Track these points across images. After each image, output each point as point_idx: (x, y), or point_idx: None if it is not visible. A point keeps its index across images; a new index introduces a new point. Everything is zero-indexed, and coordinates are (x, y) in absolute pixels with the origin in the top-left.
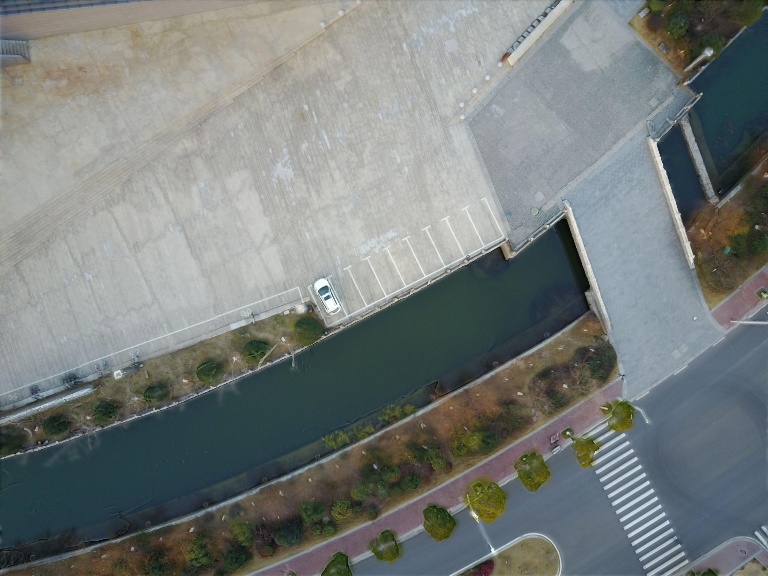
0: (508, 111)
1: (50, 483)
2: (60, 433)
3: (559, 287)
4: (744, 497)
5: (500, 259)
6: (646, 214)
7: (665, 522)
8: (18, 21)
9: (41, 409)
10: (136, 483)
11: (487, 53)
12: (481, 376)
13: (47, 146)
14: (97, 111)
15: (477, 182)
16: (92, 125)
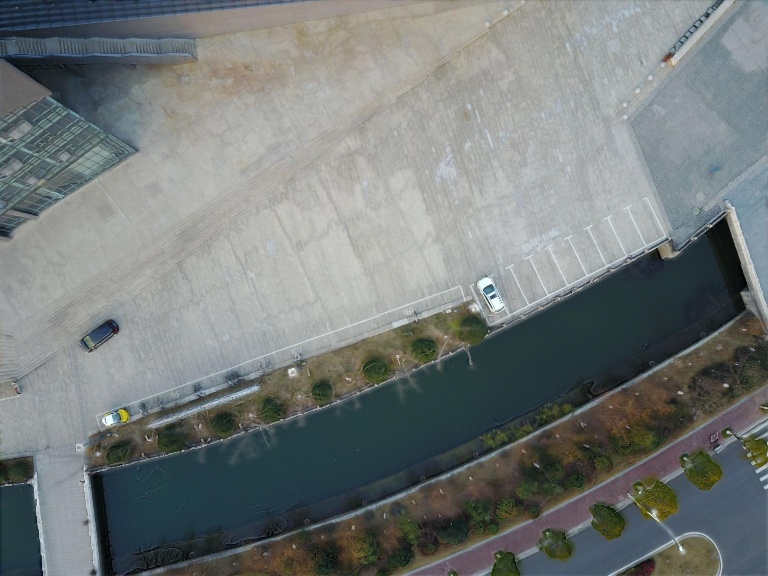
0: (669, 111)
1: (198, 481)
2: (228, 431)
3: (714, 287)
4: None
5: (656, 258)
6: None
7: None
8: (195, 20)
9: (208, 407)
10: (281, 481)
11: (649, 53)
12: (638, 375)
13: (214, 144)
14: (263, 110)
15: (639, 182)
16: (258, 123)
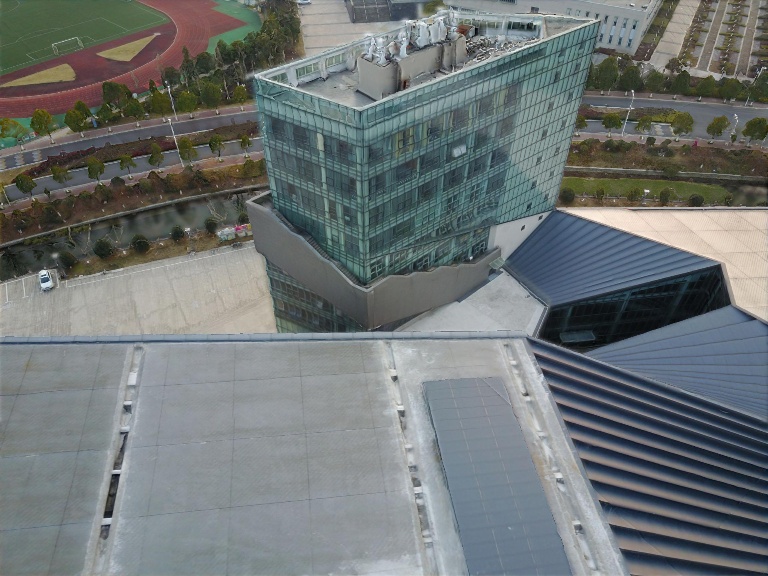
0: None
1: None
2: None
3: None
4: None
5: None
6: None
7: None
8: None
9: None
10: None
11: None
12: None
13: None
14: None
15: None
16: None
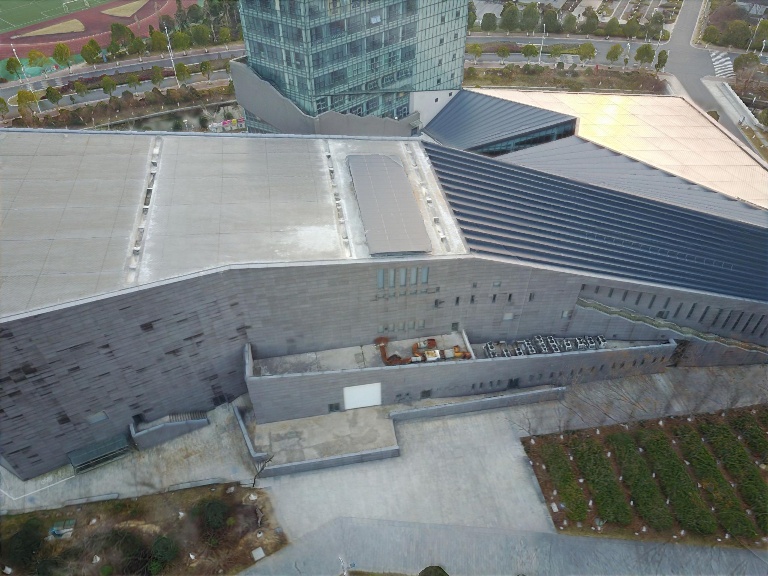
0: None
1: None
2: None
3: None
4: None
5: None
6: None
7: None
8: None
9: (235, 123)
10: None
11: None
12: None
13: None
14: None
15: None
16: None
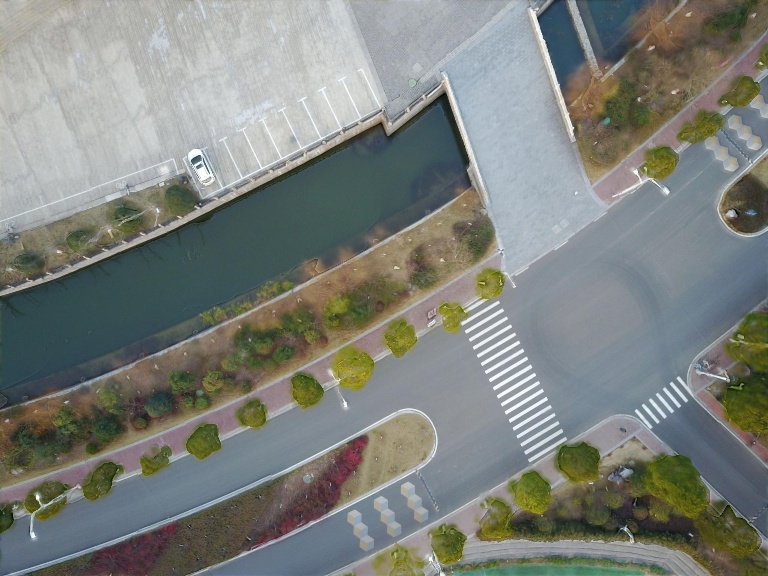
0: None
1: None
2: None
3: (442, 164)
4: (624, 374)
5: (382, 136)
6: (526, 87)
7: (543, 399)
8: None
9: None
10: (25, 368)
11: None
12: (360, 252)
13: None
14: None
15: (354, 53)
16: None
